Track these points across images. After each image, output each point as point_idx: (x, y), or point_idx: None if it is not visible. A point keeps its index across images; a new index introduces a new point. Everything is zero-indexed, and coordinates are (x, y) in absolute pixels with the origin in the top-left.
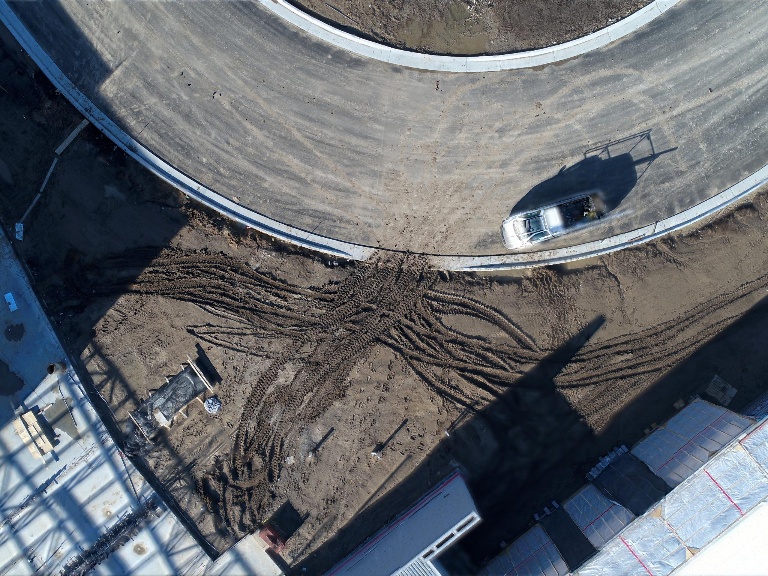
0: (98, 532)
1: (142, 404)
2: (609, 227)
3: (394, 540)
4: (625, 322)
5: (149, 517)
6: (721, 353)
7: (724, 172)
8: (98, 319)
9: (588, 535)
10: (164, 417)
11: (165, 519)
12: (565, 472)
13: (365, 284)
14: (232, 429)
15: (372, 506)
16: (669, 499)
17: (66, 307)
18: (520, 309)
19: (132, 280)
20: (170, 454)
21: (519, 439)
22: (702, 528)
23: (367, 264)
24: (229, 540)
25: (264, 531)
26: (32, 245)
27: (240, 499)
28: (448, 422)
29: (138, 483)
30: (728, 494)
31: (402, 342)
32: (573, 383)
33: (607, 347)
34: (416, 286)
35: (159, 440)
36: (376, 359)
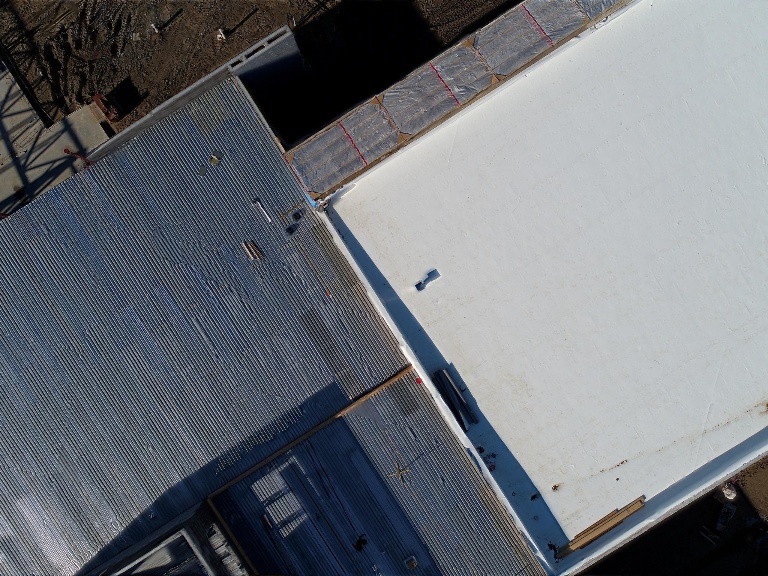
0: None
1: None
2: None
3: None
4: None
5: None
6: None
7: None
8: None
9: None
10: None
11: (3, 79)
12: None
13: None
14: None
15: None
16: (484, 31)
17: None
18: None
19: None
20: (16, 16)
21: (368, 42)
22: (512, 57)
23: None
24: (66, 111)
25: (98, 95)
26: None
27: (81, 70)
28: (298, 16)
29: None
30: (542, 26)
31: None
32: None
33: None
34: None
35: (6, 0)
36: None
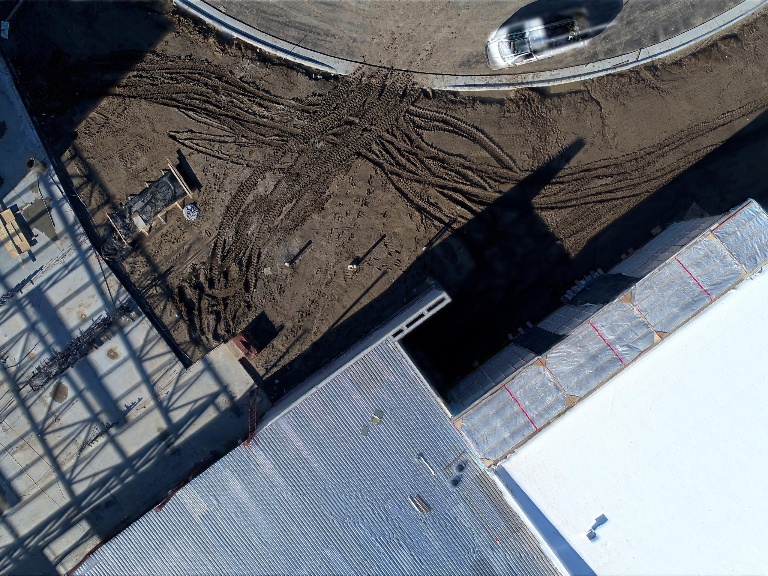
0: (72, 335)
1: (121, 207)
2: (593, 52)
3: (366, 342)
4: (606, 146)
5: (124, 322)
6: (700, 181)
7: (709, 2)
8: (80, 121)
9: (559, 331)
10: (142, 221)
11: (140, 324)
12: (540, 294)
13: (348, 98)
14: (210, 237)
15: (347, 321)
16: (640, 286)
17: (49, 108)
18: (502, 129)
19: (116, 83)
20: (147, 260)
21: (496, 259)
22: (671, 313)
23: (351, 79)
24: (203, 349)
25: (238, 337)
26: (17, 44)
27: (215, 309)
28: (426, 239)
29: (114, 287)
30: (698, 280)
31: (383, 157)
32: (552, 205)
33: (587, 170)
34: (399, 101)
35: (137, 246)
36: (356, 173)
